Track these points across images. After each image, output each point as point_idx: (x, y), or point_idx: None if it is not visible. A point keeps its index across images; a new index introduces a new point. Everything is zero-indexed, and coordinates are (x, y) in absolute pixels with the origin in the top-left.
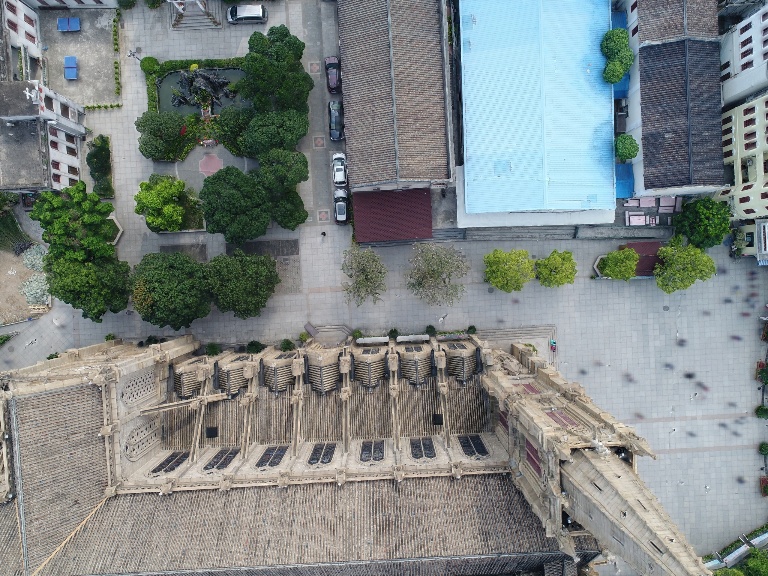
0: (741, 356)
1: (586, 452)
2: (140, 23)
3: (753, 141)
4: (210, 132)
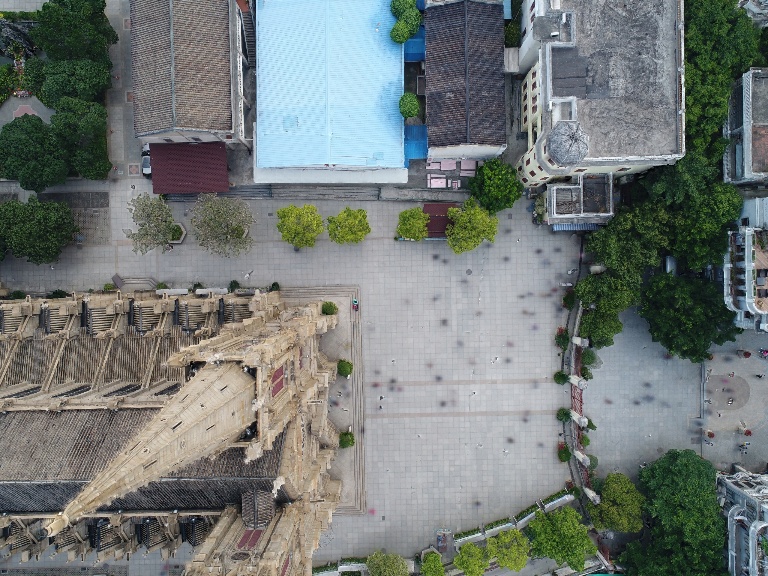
0: (542, 322)
1: (210, 365)
2: None
3: (535, 104)
4: (24, 83)
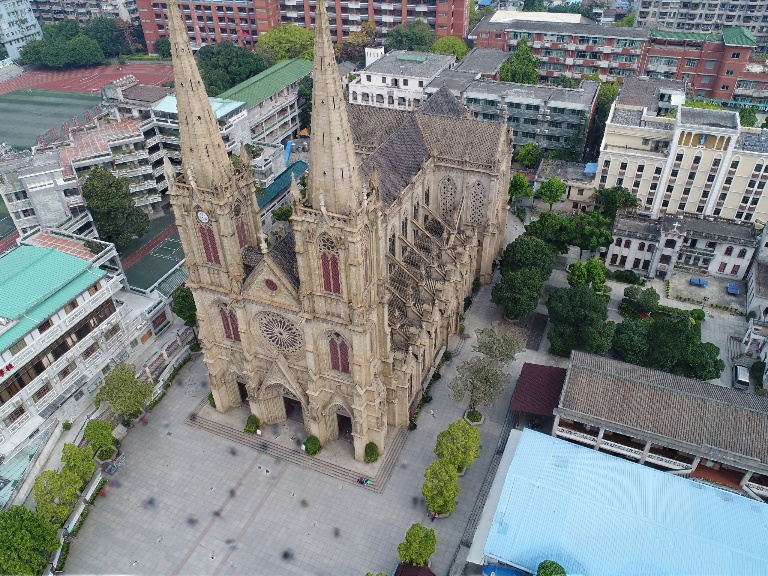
0: None
1: None
2: (735, 323)
3: None
4: None
